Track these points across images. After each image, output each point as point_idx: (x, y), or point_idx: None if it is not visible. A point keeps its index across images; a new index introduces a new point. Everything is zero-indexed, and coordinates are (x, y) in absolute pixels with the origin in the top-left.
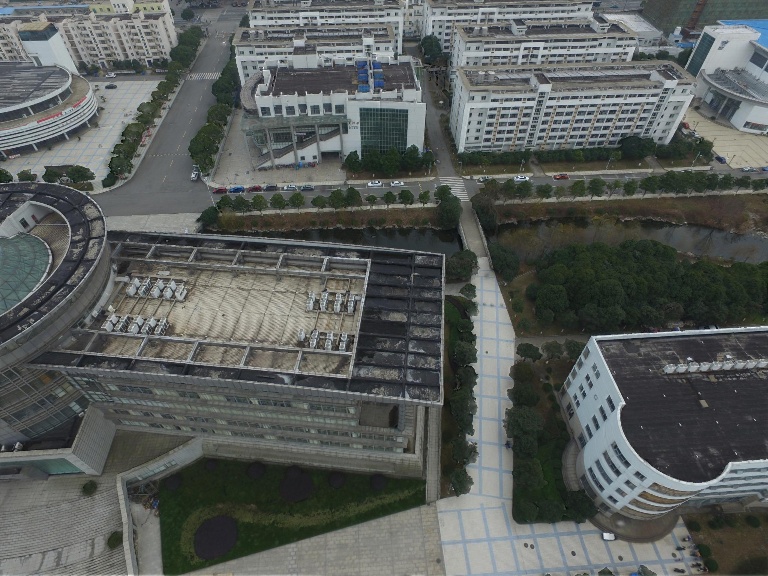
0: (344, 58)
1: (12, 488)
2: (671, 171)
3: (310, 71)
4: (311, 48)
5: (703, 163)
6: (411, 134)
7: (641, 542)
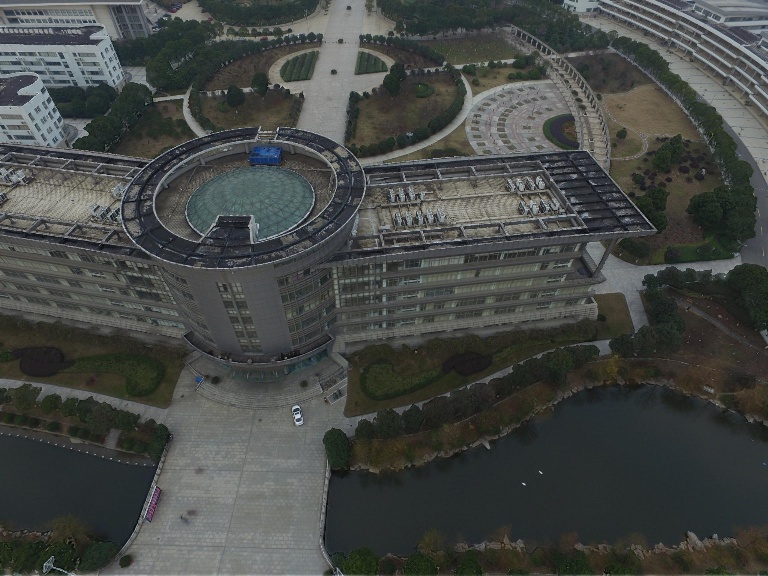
0: None
1: None
2: None
3: None
4: None
5: None
6: None
7: None
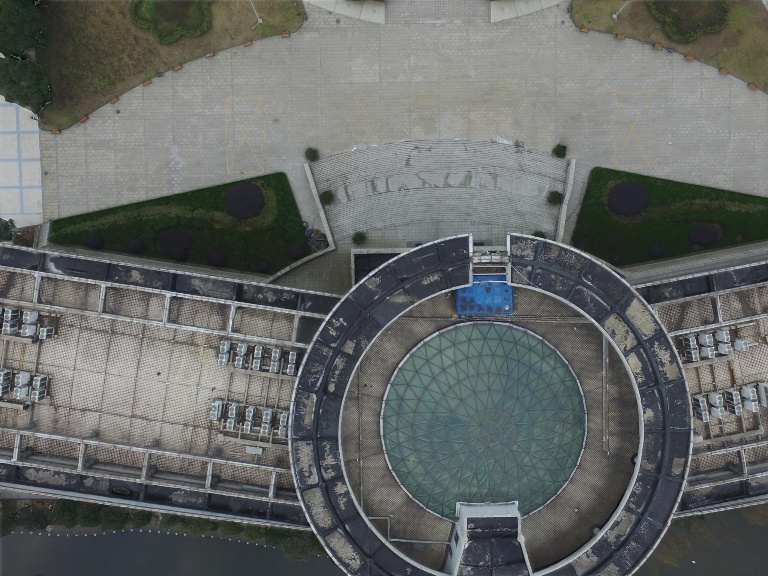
0: None
1: None
2: None
3: None
4: None
5: None
6: None
7: None
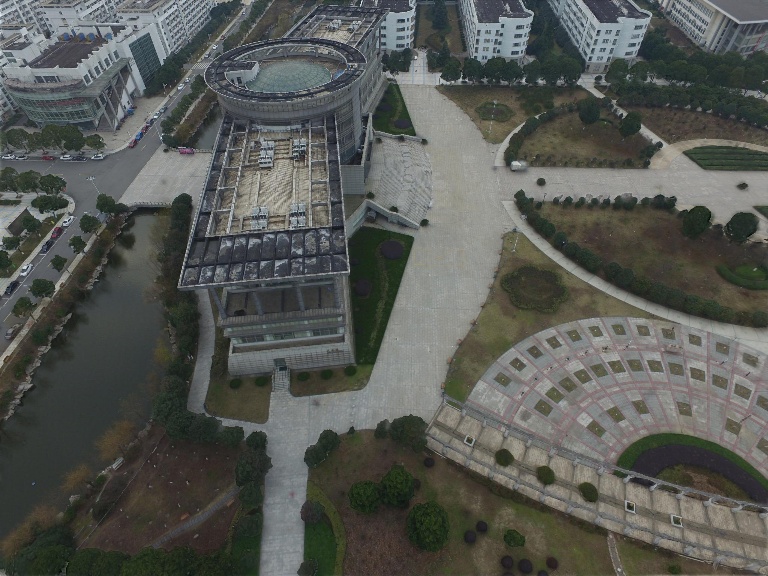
0: (46, 40)
1: (373, 163)
2: (253, 4)
3: (44, 57)
4: (15, 45)
5: (240, 8)
6: (158, 51)
7: (418, 55)
